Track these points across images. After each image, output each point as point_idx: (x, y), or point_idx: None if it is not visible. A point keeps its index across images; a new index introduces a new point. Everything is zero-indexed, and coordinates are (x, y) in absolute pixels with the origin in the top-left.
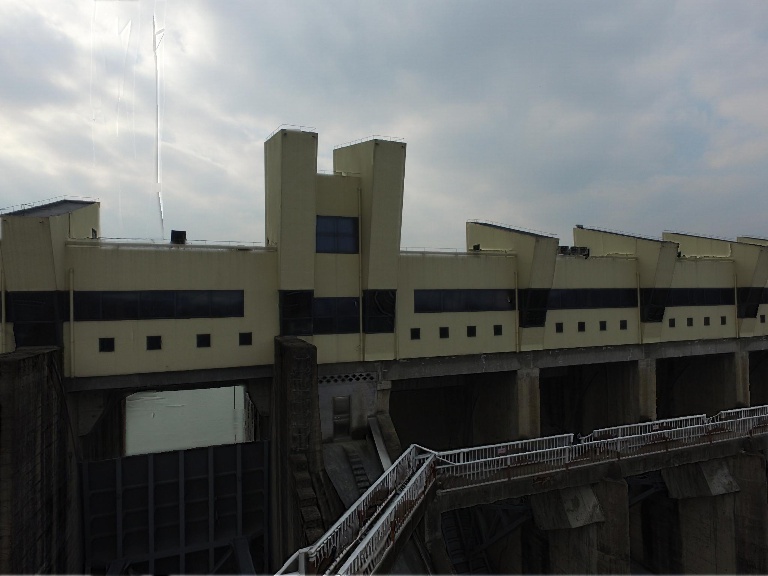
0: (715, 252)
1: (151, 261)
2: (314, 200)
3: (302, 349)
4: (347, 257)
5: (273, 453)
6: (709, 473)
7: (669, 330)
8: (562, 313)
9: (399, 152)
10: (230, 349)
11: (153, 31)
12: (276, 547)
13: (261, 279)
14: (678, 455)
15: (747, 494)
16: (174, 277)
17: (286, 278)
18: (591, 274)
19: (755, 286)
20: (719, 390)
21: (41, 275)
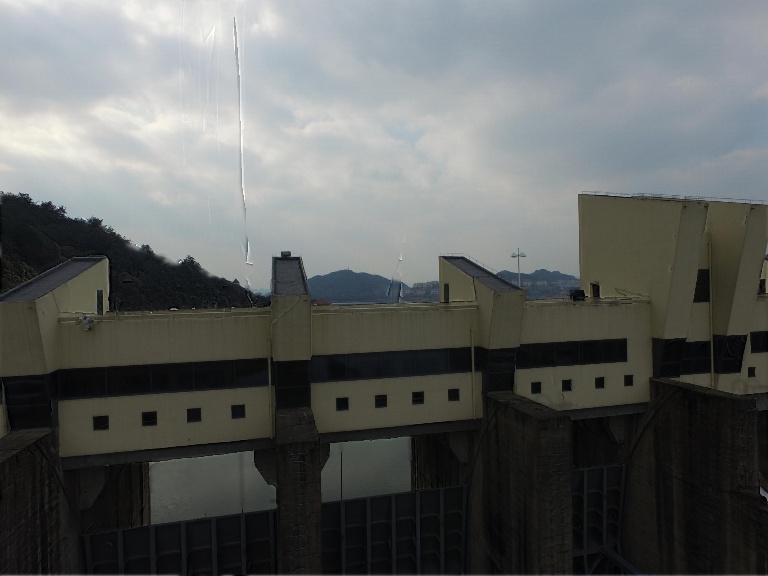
0: None
1: (563, 317)
2: (697, 261)
3: (746, 401)
4: (700, 305)
5: (643, 477)
6: None
7: None
8: None
9: (767, 214)
10: (618, 389)
11: (235, 35)
12: (652, 558)
13: (638, 328)
14: None
15: None
16: (578, 330)
17: (668, 329)
18: None
19: None
20: None
21: (511, 336)
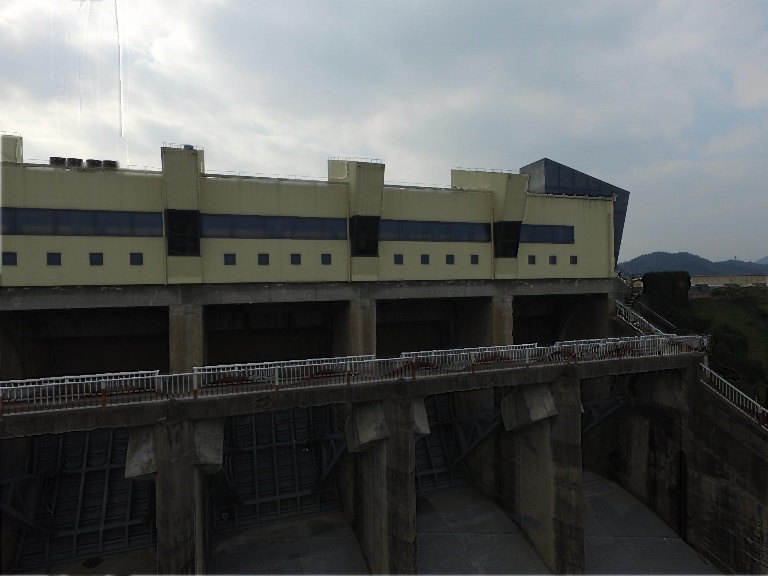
0: (342, 176)
1: None
2: None
3: None
4: None
5: None
6: (133, 448)
7: (224, 268)
8: (15, 240)
9: None
10: None
11: (114, 5)
12: None
13: None
14: (23, 422)
15: (159, 476)
16: None
17: None
18: (75, 190)
19: (362, 214)
20: (345, 349)
21: None
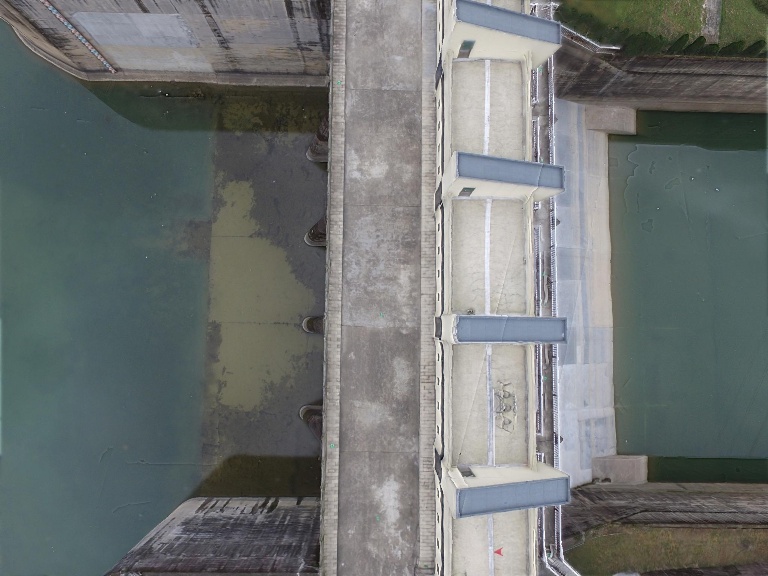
0: None
1: None
2: None
3: None
4: None
5: None
6: None
7: None
8: None
9: None
10: None
11: None
12: None
13: None
14: None
15: None
16: None
17: None
18: None
19: None
20: None
21: None
